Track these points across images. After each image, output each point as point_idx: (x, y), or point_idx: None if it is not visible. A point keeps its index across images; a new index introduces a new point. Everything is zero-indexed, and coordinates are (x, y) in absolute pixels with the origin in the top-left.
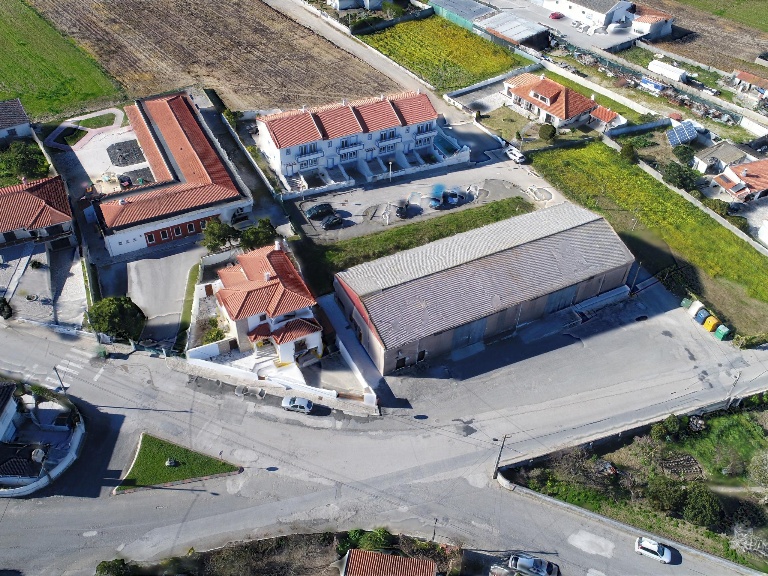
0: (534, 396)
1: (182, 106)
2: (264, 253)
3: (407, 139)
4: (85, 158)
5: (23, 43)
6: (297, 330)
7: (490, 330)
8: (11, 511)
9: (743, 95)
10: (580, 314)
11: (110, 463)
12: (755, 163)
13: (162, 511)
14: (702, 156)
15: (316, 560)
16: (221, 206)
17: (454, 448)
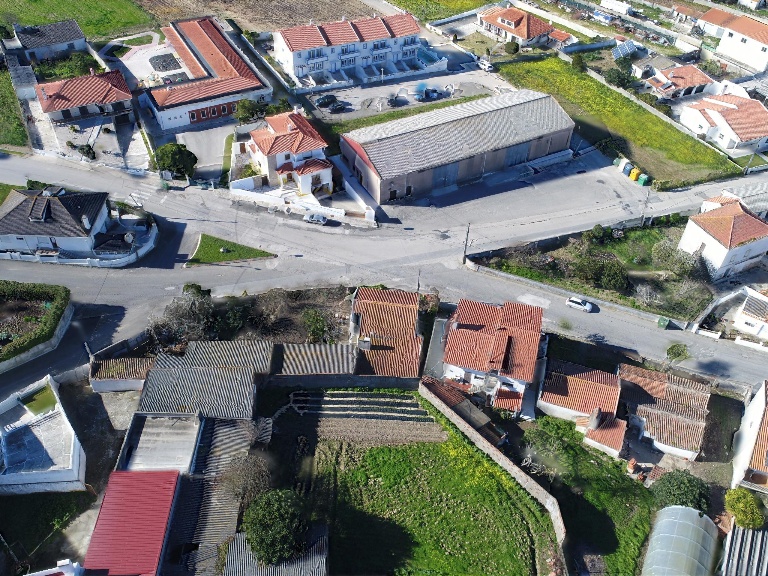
0: (495, 217)
1: (209, 26)
2: (286, 115)
3: (396, 50)
4: (132, 66)
5: None
6: (314, 166)
7: (462, 175)
8: (111, 275)
9: (680, 25)
10: (533, 169)
11: (179, 250)
12: (681, 68)
13: (220, 277)
14: (639, 64)
15: (334, 303)
16: (248, 93)
17: (434, 246)
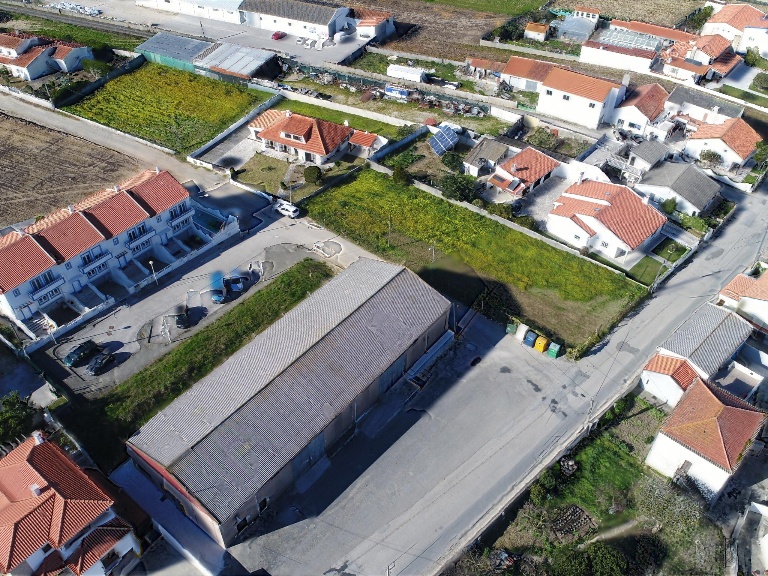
0: (402, 502)
1: None
2: (22, 456)
3: (161, 229)
4: None
5: None
6: (99, 545)
7: (329, 440)
8: None
9: (482, 82)
10: (415, 380)
11: None
12: (520, 155)
13: None
14: (470, 160)
15: None
16: None
17: None
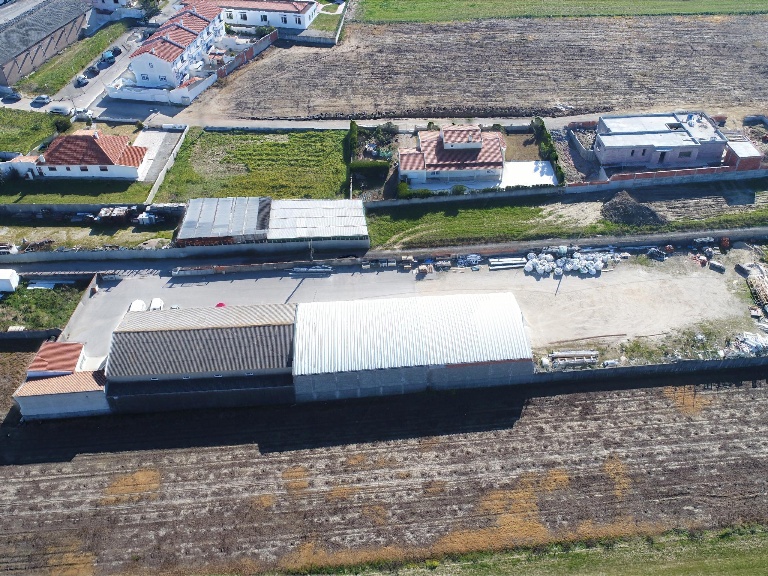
0: None
1: (285, 8)
2: None
3: None
4: None
5: (474, 6)
6: None
7: None
8: None
9: None
10: None
11: None
12: None
13: None
14: None
15: None
16: None
17: None
